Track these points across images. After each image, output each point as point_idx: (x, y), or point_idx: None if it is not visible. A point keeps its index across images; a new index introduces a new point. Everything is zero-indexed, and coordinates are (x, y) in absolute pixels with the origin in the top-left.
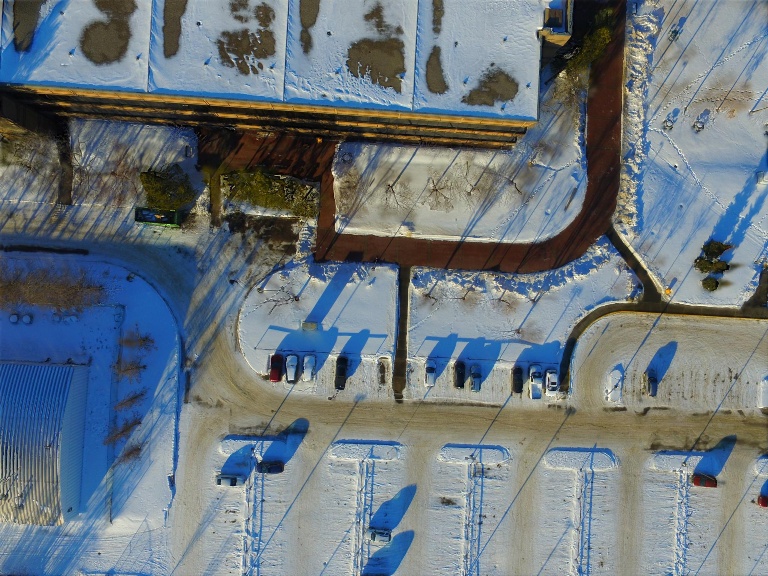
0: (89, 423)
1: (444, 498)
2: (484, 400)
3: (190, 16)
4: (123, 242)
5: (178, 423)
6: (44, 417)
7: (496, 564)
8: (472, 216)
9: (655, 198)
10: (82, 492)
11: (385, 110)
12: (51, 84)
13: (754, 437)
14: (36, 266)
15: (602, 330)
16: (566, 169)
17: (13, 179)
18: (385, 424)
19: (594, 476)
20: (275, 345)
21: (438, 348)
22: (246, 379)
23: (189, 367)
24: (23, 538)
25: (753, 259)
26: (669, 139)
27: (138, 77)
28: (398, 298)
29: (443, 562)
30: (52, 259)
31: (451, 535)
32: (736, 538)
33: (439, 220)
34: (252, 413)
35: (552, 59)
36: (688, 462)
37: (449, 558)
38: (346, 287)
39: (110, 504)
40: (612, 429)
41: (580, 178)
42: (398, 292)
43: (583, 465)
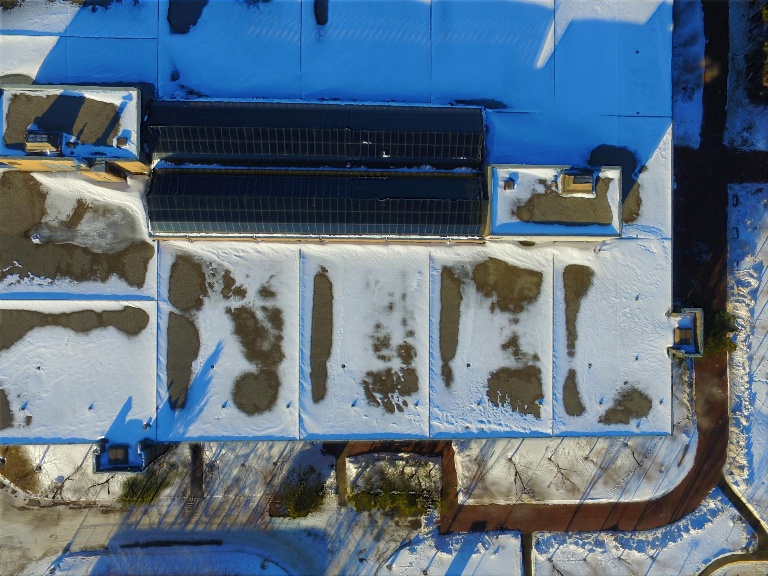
0: None
1: None
2: None
3: (335, 359)
4: (255, 530)
5: None
6: None
7: None
8: (589, 479)
9: (764, 449)
10: None
11: None
12: (206, 439)
13: None
14: (172, 561)
15: None
16: (677, 426)
17: (146, 478)
18: None
19: None
20: None
21: None
22: None
23: None
24: None
25: None
26: None
27: (289, 424)
28: (522, 564)
29: None
30: (187, 552)
31: None
32: None
33: None
34: None
35: None
36: None
37: None
38: (472, 558)
39: None
40: None
41: (691, 434)
42: (522, 558)
43: None
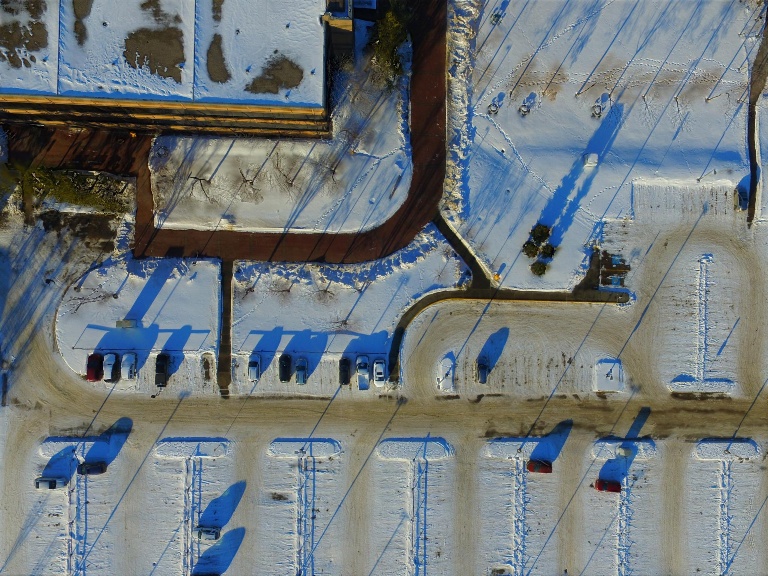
0: None
1: (275, 493)
2: (313, 393)
3: None
4: None
5: None
6: None
7: (331, 558)
8: (294, 207)
9: (481, 184)
10: None
11: (165, 101)
12: None
13: (590, 421)
14: None
15: (431, 318)
16: (390, 157)
17: None
18: (211, 421)
19: (428, 466)
20: (93, 344)
21: (263, 342)
22: (65, 380)
23: (6, 369)
24: None
25: (583, 242)
26: (495, 124)
27: None
28: (221, 292)
29: (276, 558)
30: None
31: (284, 530)
32: (576, 523)
33: (260, 212)
34: (73, 414)
35: (364, 46)
36: (524, 448)
37: (282, 554)
38: (166, 283)
39: None
40: (445, 418)
41: (404, 166)
42: (221, 286)
43: (416, 455)
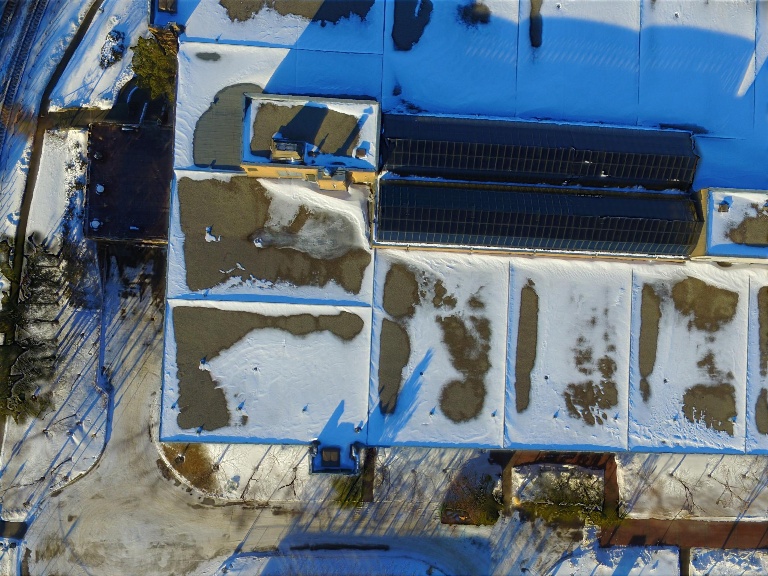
0: None
1: None
2: None
3: (538, 371)
4: (421, 536)
5: None
6: None
7: None
8: (747, 497)
9: None
10: None
11: (720, 453)
12: (415, 444)
13: None
14: (341, 564)
15: None
16: None
17: (319, 481)
18: None
19: None
20: None
21: None
22: None
23: None
24: None
25: None
26: None
27: (494, 433)
28: None
29: None
30: (355, 556)
31: None
32: None
33: None
34: None
35: None
36: None
37: None
38: (631, 571)
39: None
40: None
41: None
42: (679, 574)
43: None
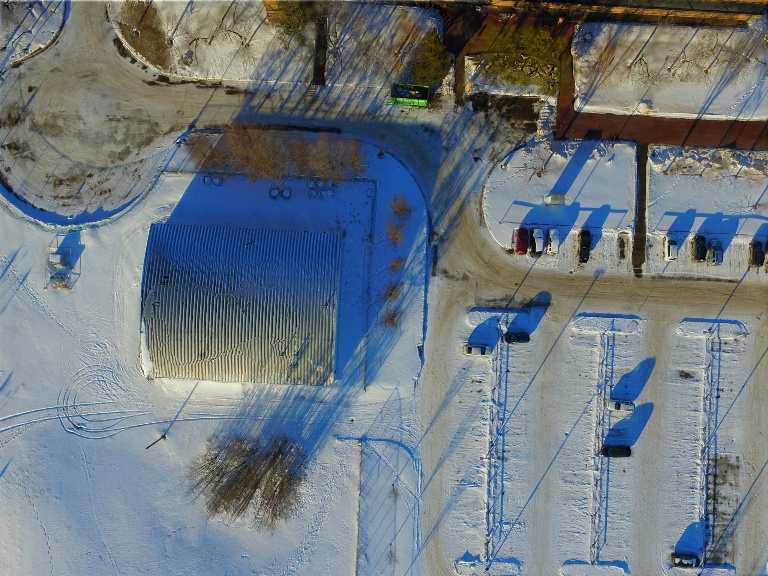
0: (344, 294)
1: (682, 371)
2: (721, 275)
3: None
4: (373, 121)
5: (427, 295)
6: (320, 278)
7: (733, 437)
8: (709, 94)
9: None
10: (339, 359)
11: None
12: None
13: None
14: (292, 144)
15: None
16: None
17: (271, 60)
18: (625, 298)
19: None
20: (520, 219)
21: (677, 223)
22: (491, 253)
23: (436, 241)
24: (282, 404)
25: None
26: None
27: None
28: (637, 174)
29: (682, 434)
30: (307, 137)
31: (689, 408)
32: None
33: (676, 98)
34: (497, 286)
35: None
36: None
37: (688, 430)
38: (586, 164)
39: (364, 372)
40: None
41: None
42: (636, 169)
43: None
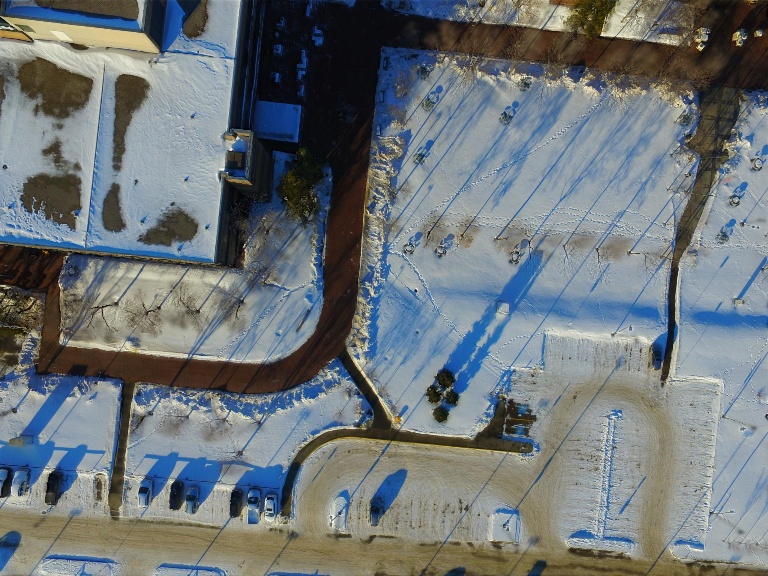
0: None
1: None
2: (203, 521)
3: None
4: None
5: None
6: None
7: None
8: (200, 334)
9: (390, 323)
10: None
11: (57, 247)
12: None
13: (483, 570)
14: None
15: (328, 455)
16: (300, 290)
17: None
18: (100, 541)
19: None
20: None
21: (157, 467)
22: None
23: None
24: None
25: (489, 389)
26: (410, 263)
27: None
28: (120, 414)
29: None
30: None
31: None
32: None
33: (166, 337)
34: None
35: (278, 183)
36: None
37: None
38: (66, 401)
39: None
40: (335, 556)
41: (314, 300)
42: (120, 408)
43: None
